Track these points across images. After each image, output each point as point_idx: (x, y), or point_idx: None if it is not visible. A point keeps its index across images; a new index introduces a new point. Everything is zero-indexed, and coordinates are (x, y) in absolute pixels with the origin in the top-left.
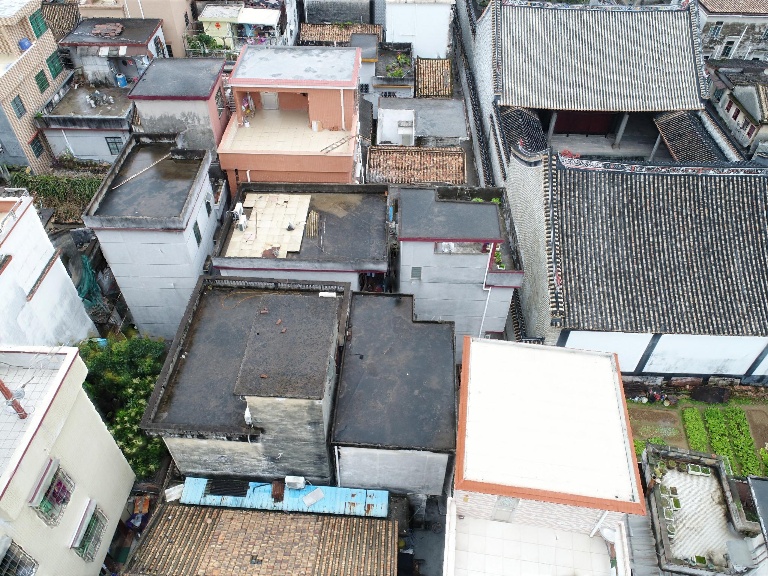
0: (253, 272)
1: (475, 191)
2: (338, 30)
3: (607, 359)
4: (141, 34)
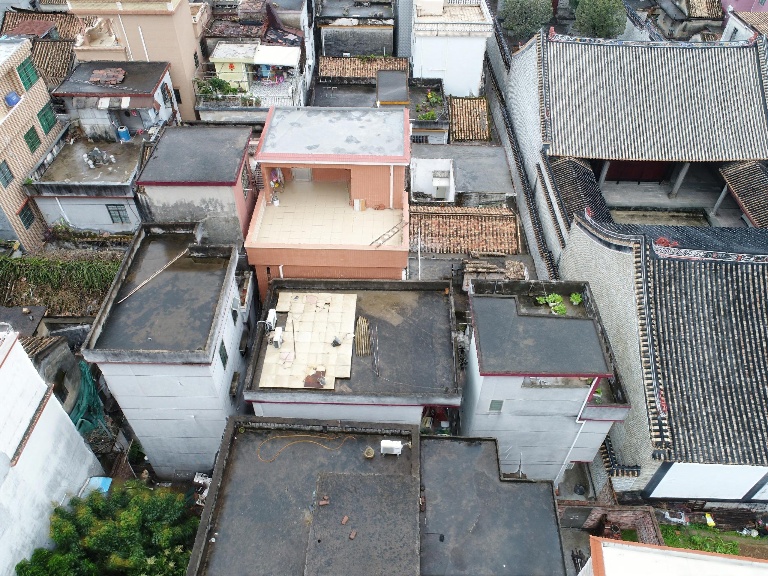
0: (293, 405)
1: (551, 285)
2: (360, 64)
3: None
4: (146, 81)
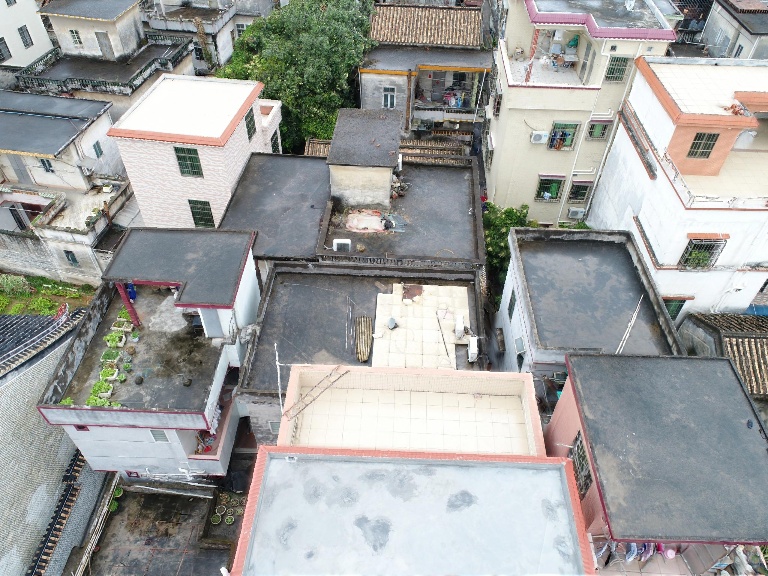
0: None
1: None
2: None
3: None
4: None
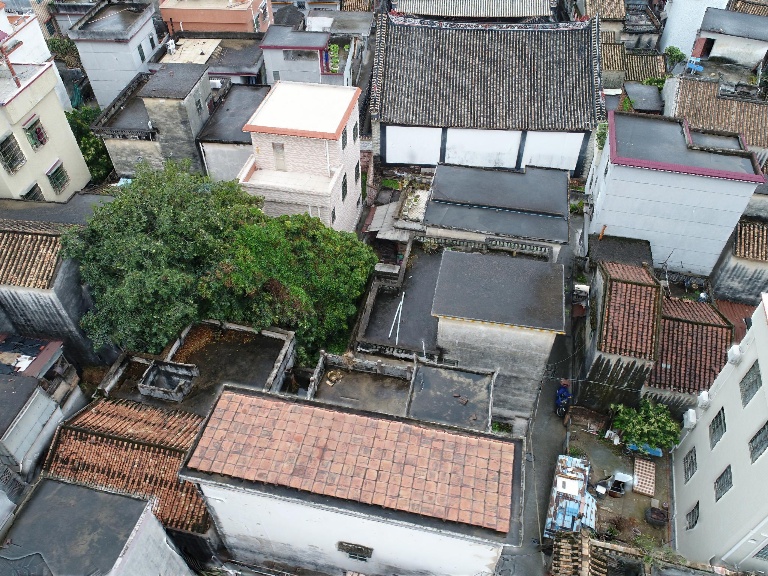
0: None
1: (333, 40)
2: None
3: (354, 91)
4: None
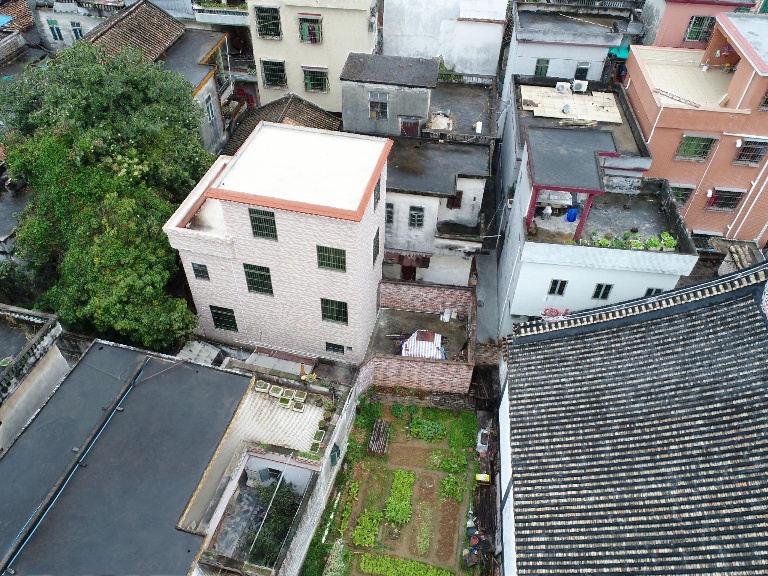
0: None
1: None
2: None
3: None
4: None
